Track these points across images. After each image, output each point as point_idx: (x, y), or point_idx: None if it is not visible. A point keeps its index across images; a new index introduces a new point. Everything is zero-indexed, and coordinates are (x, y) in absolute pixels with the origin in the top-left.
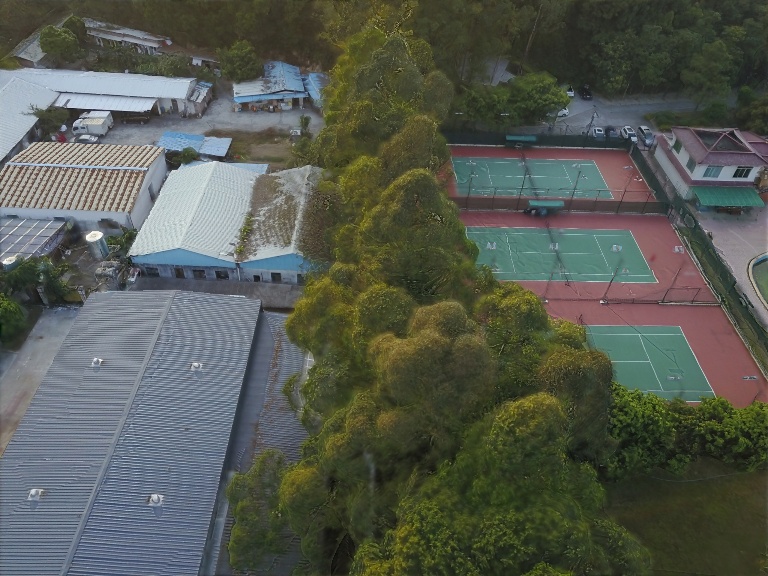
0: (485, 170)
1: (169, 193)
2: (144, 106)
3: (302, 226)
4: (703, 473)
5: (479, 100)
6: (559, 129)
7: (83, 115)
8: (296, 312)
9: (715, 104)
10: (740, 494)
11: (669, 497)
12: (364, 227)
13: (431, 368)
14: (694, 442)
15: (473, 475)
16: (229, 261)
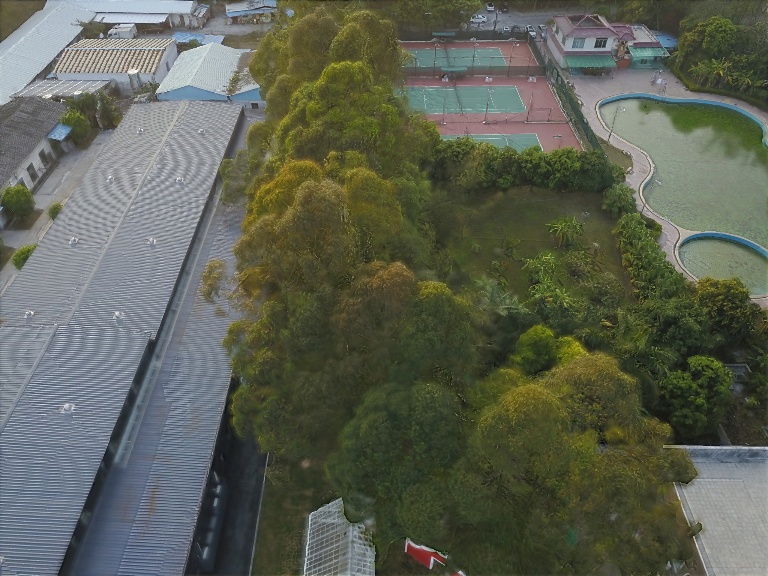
0: (415, 55)
1: (180, 62)
2: (159, 19)
3: None
4: (529, 199)
5: (409, 4)
6: (474, 27)
7: (115, 26)
8: None
9: (600, 7)
10: (550, 208)
11: (504, 210)
12: None
13: (307, 31)
14: (513, 166)
15: None
16: (222, 95)
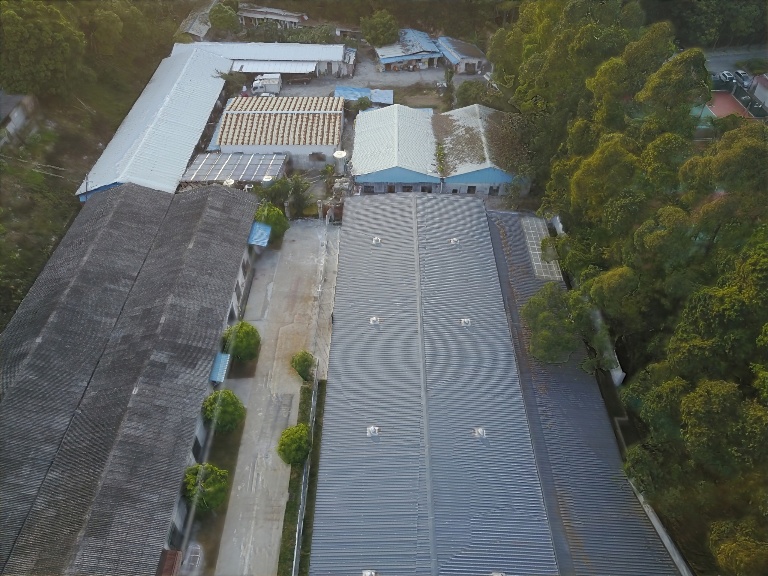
0: None
1: (364, 130)
2: (308, 68)
3: (489, 148)
4: None
5: None
6: None
7: (258, 77)
8: (584, 168)
9: None
10: None
11: None
12: (642, 98)
13: (753, 161)
14: None
15: None
16: (435, 177)
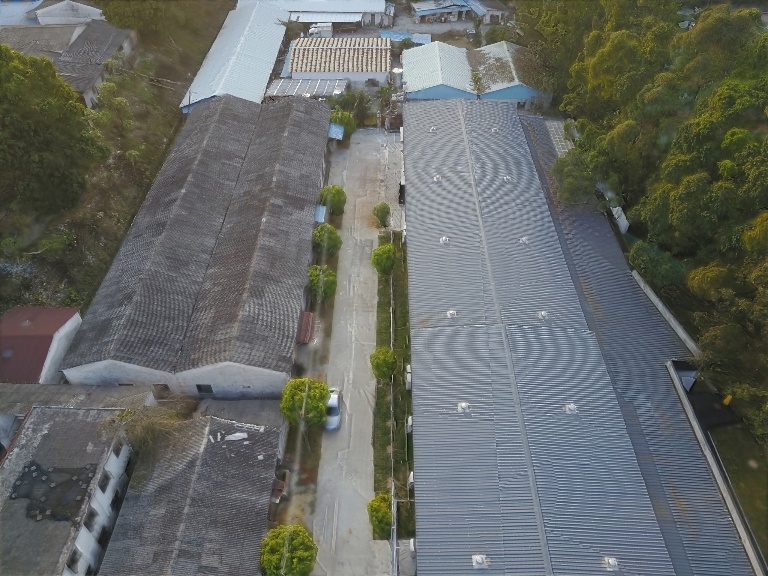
0: None
1: (411, 61)
2: (355, 18)
3: (517, 71)
4: None
5: None
6: None
7: (313, 26)
8: (599, 55)
9: None
10: None
11: None
12: None
13: (720, 28)
14: None
15: (745, 74)
16: (473, 93)
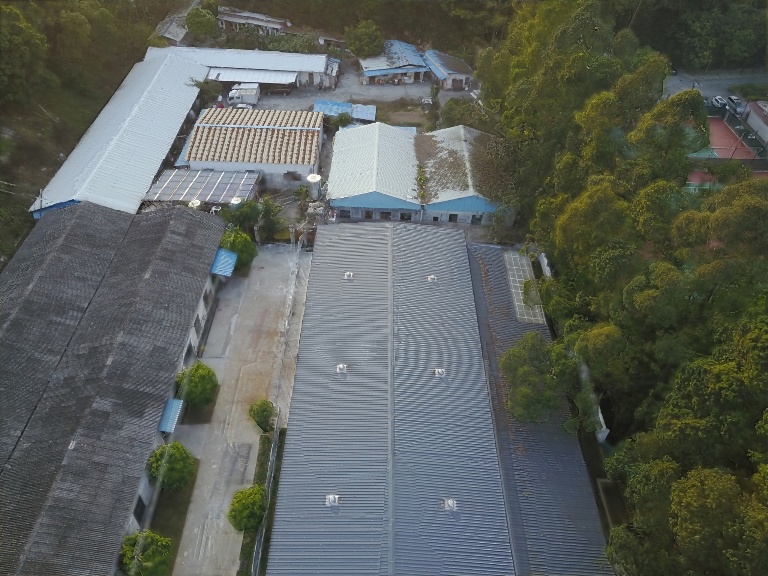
0: None
1: (343, 149)
2: (288, 79)
3: (473, 174)
4: None
5: None
6: None
7: (235, 87)
8: (571, 212)
9: None
10: None
11: None
12: (636, 140)
13: (756, 223)
14: None
15: None
16: (416, 203)
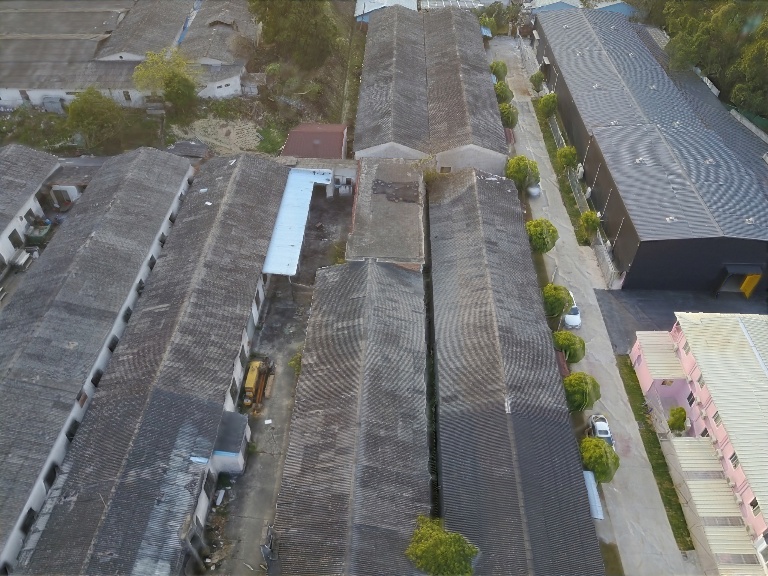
0: None
1: None
2: None
3: None
4: None
5: None
6: None
7: None
8: None
9: None
10: None
11: None
12: None
13: None
14: None
15: None
16: None
